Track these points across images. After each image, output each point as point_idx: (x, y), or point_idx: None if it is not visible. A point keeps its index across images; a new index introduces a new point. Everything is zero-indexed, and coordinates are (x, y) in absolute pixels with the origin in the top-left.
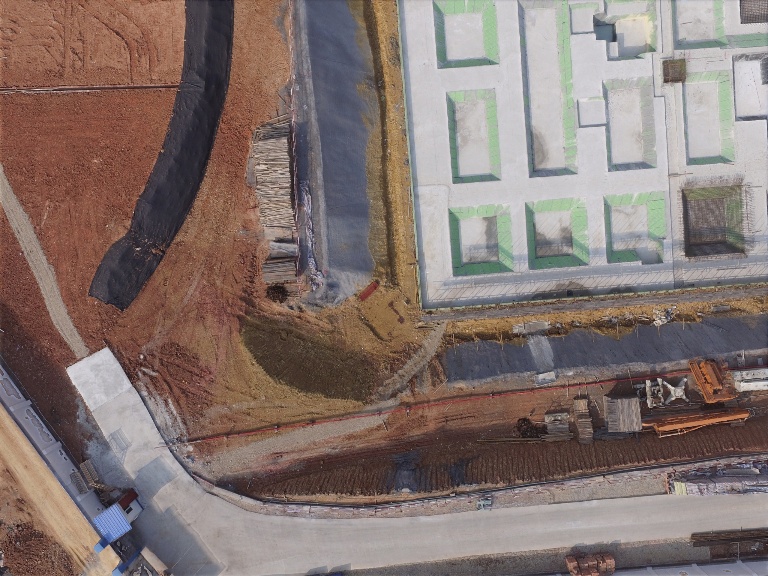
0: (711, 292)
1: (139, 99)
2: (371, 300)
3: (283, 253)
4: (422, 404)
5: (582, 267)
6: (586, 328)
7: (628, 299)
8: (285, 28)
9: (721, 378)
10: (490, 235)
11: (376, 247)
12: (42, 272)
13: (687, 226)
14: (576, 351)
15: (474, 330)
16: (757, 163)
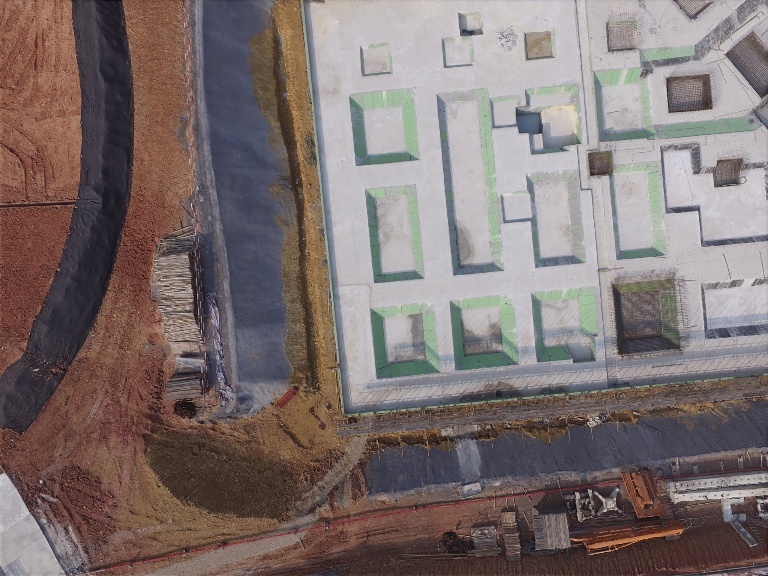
0: (640, 400)
1: (34, 217)
2: (291, 406)
3: (190, 368)
4: (342, 519)
5: (511, 366)
6: (517, 430)
7: (553, 409)
8: (187, 139)
9: (652, 491)
10: (416, 333)
11: (294, 352)
12: None
13: (621, 320)
14: (505, 457)
15: (400, 433)
16: (690, 256)
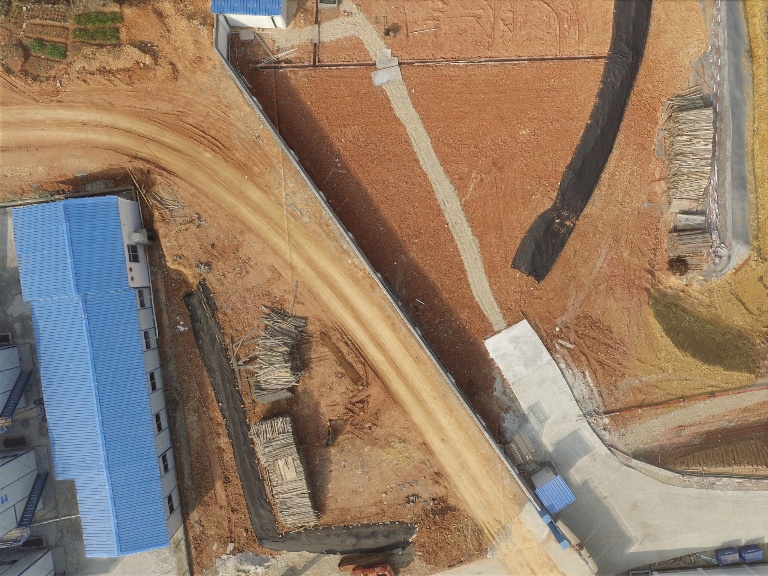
0: None
1: (567, 70)
2: (741, 275)
3: (690, 225)
4: None
5: None
6: None
7: None
8: None
9: None
10: None
11: (751, 221)
12: (466, 244)
13: None
14: None
15: None
16: None
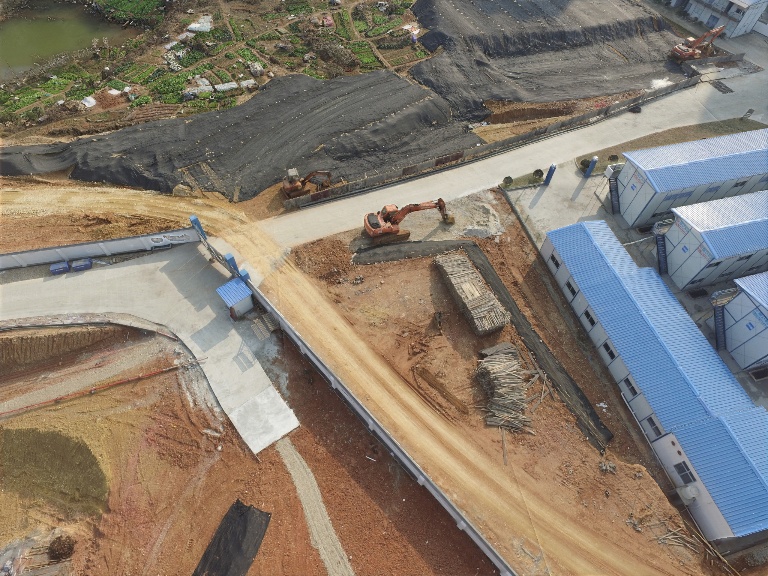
0: None
1: None
2: None
3: None
4: None
5: None
6: None
7: None
8: None
9: None
10: None
11: None
12: (325, 536)
13: None
14: None
15: None
16: None
